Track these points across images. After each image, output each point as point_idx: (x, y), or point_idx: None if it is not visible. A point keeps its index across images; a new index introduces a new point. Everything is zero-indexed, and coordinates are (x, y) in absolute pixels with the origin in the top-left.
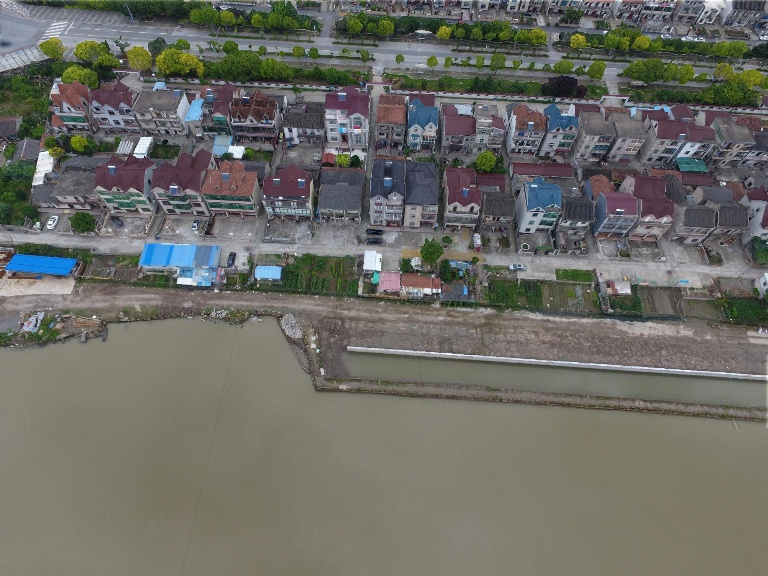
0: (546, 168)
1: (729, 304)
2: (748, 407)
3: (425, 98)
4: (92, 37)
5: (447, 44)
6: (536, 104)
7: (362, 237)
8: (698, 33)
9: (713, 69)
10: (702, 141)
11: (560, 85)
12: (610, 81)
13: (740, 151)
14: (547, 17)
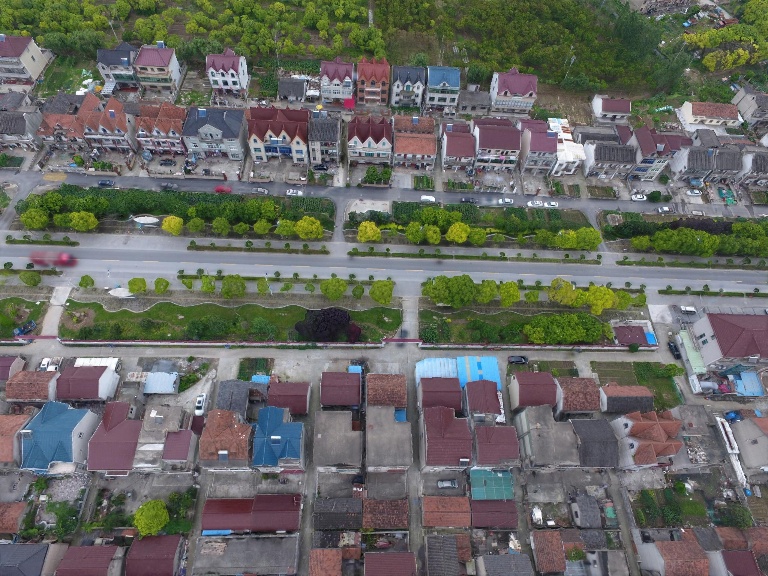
0: (256, 516)
1: None
2: None
3: (82, 383)
4: None
5: (184, 234)
6: (288, 351)
7: None
8: (550, 193)
9: (559, 264)
10: (498, 463)
11: (319, 327)
12: (409, 296)
13: (560, 467)
14: (348, 172)
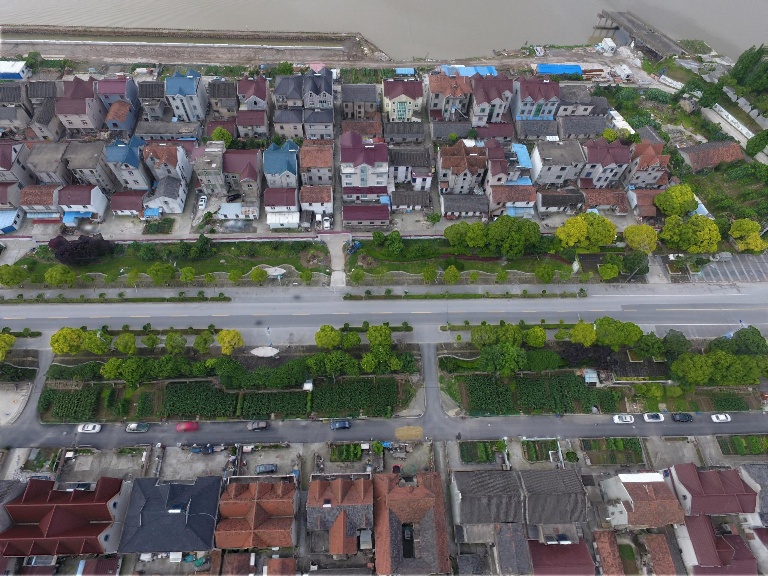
0: None
1: (63, 67)
2: (97, 31)
3: None
4: (752, 305)
5: None
6: None
7: None
8: None
9: None
10: None
11: (86, 241)
12: None
13: None
14: None
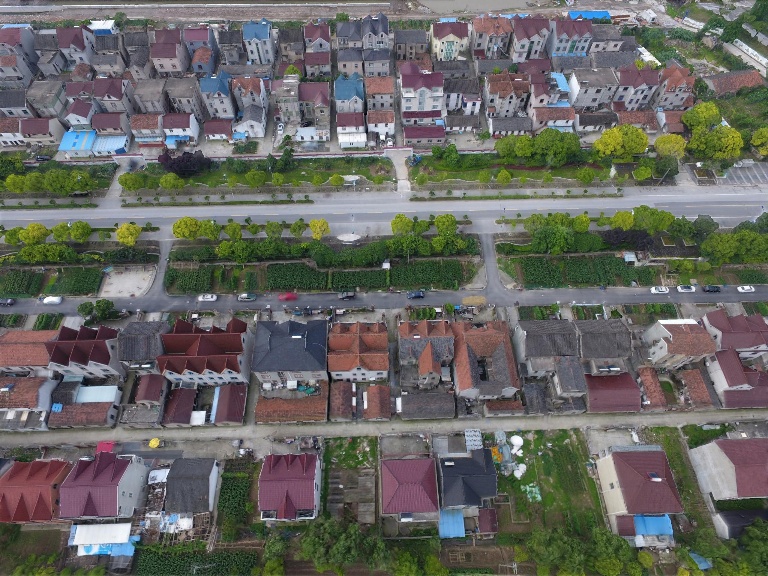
0: None
1: (145, 26)
2: None
3: None
4: None
5: None
6: None
7: (391, 42)
8: None
9: None
10: None
11: (190, 156)
12: (113, 198)
13: None
14: None
